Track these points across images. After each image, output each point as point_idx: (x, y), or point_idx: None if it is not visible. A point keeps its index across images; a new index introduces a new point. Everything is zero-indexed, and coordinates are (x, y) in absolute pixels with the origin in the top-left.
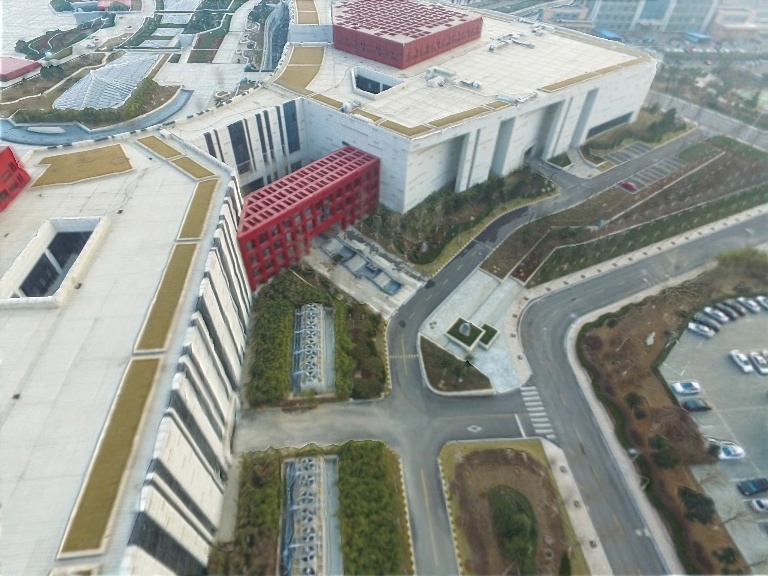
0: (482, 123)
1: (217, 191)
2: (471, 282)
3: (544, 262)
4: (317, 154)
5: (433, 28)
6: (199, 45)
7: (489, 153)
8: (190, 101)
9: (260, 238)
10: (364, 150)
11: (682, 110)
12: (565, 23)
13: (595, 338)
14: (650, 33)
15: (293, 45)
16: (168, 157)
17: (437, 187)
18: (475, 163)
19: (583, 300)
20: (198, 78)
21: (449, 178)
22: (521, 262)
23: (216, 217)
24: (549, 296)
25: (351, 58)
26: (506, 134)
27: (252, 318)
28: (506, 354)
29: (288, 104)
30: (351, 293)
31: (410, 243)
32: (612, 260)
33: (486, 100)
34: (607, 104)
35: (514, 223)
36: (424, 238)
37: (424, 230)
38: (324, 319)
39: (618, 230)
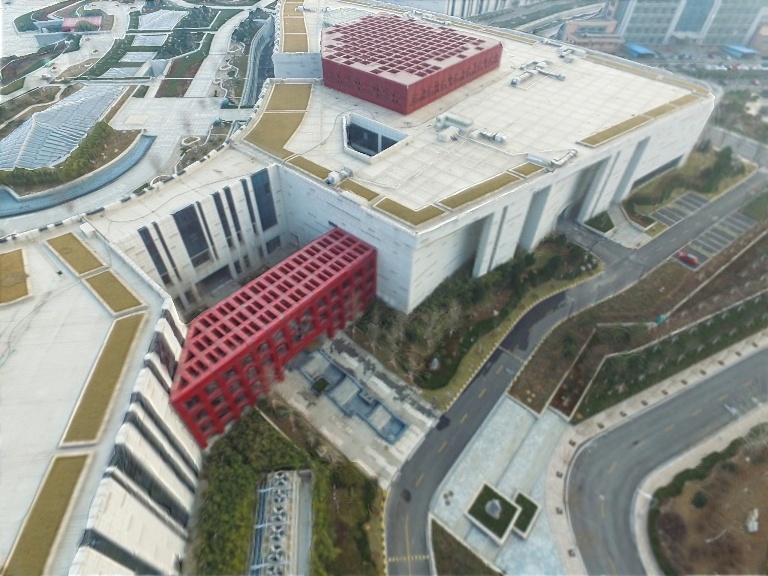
0: (510, 199)
1: (139, 337)
2: (498, 419)
3: (592, 381)
4: (299, 229)
5: (443, 61)
6: (172, 73)
7: (517, 229)
8: (150, 151)
9: (207, 389)
10: (356, 235)
11: (738, 148)
12: (591, 38)
13: (674, 519)
14: (686, 47)
15: (274, 82)
16: (82, 272)
17: (450, 271)
18: (499, 243)
19: (648, 443)
20: (165, 118)
21: (466, 259)
22: (562, 383)
23: (129, 392)
24: (602, 437)
25: (343, 99)
26: (539, 206)
27: (199, 494)
28: (551, 547)
29: (258, 175)
30: (337, 443)
31: (416, 356)
32: (679, 374)
33: (513, 161)
34: (657, 152)
35: (549, 319)
36: (435, 347)
37: (435, 337)
38: (298, 495)
39: (682, 326)
